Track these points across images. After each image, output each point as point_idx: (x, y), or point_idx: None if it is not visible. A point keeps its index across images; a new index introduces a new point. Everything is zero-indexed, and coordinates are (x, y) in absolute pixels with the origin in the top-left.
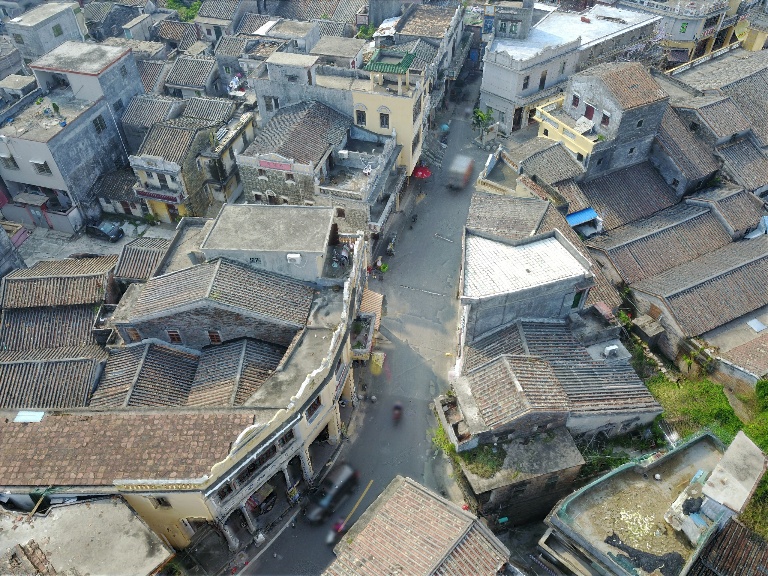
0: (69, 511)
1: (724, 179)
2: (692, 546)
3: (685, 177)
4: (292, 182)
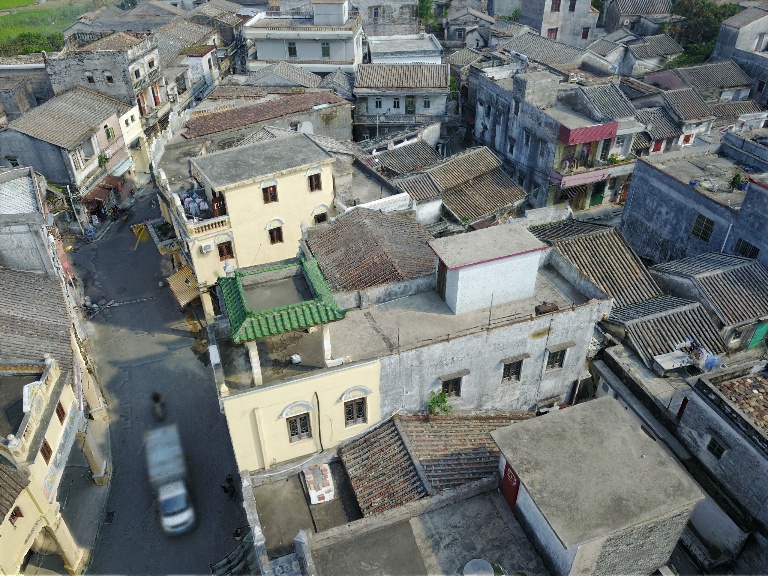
0: None
1: None
2: None
3: None
4: None
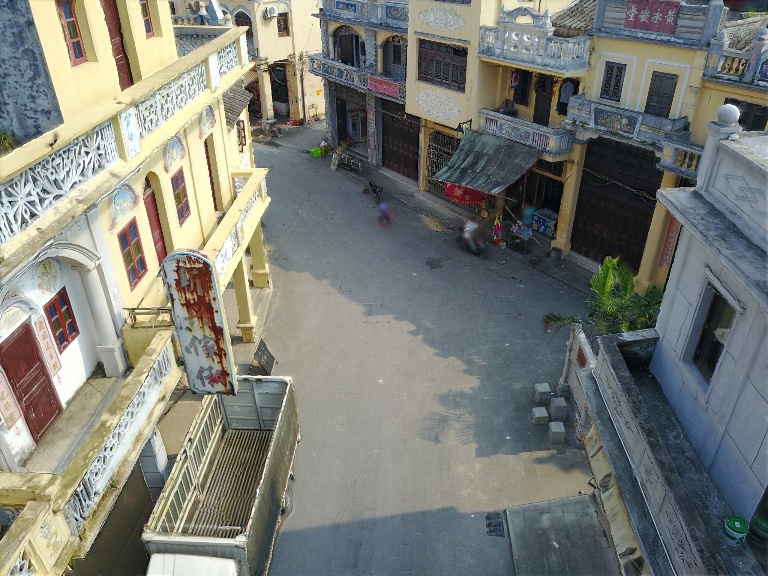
0: None
1: None
2: None
3: None
4: None
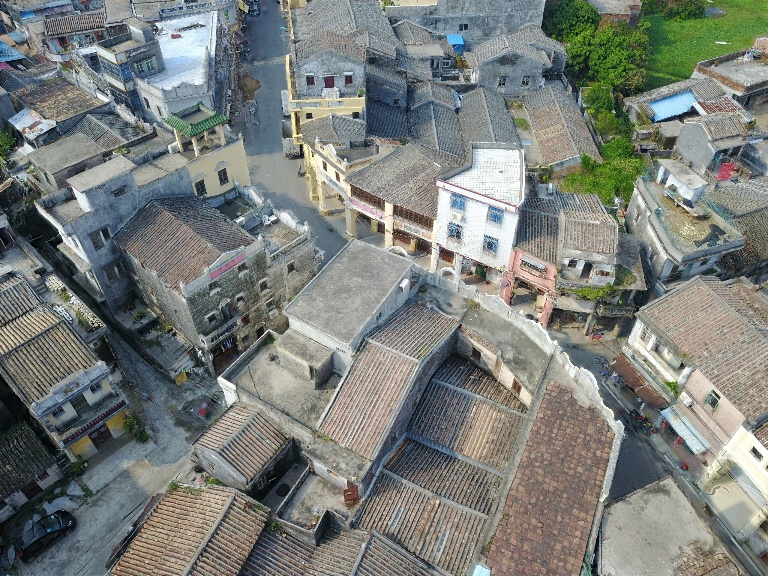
0: (608, 558)
1: (413, 84)
2: (708, 217)
3: (403, 93)
4: (245, 271)
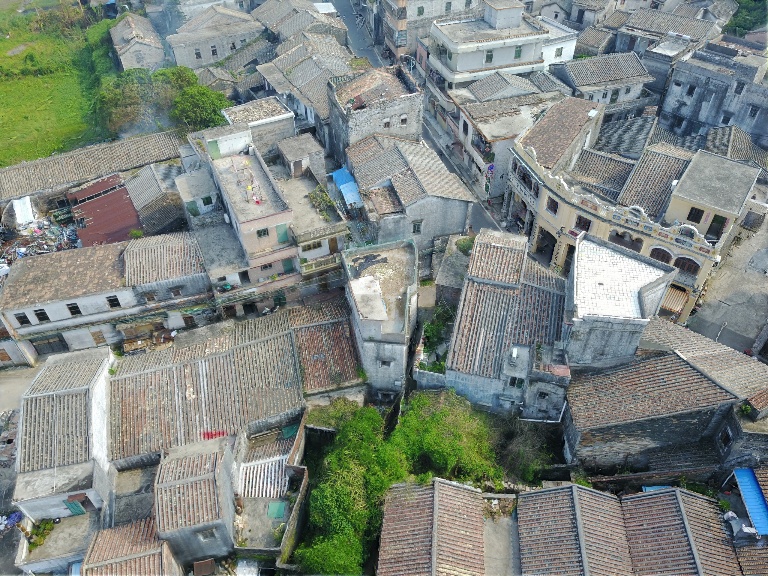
0: None
1: None
2: None
3: None
4: None
